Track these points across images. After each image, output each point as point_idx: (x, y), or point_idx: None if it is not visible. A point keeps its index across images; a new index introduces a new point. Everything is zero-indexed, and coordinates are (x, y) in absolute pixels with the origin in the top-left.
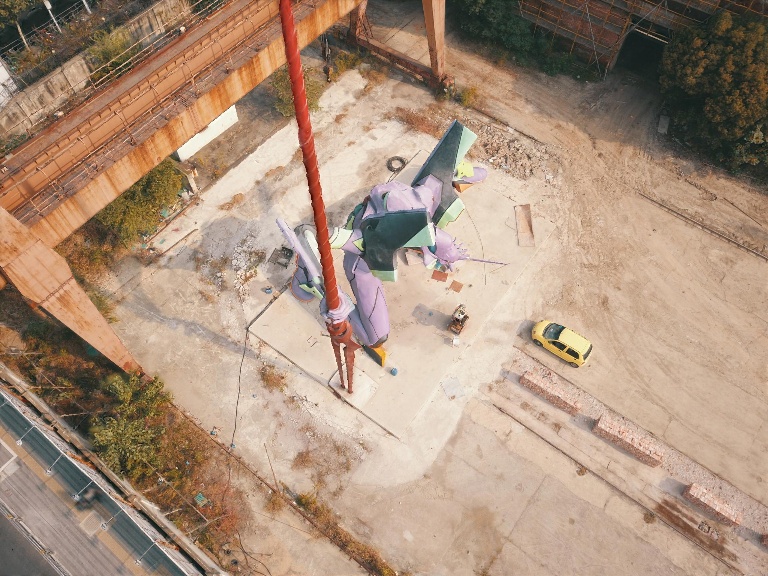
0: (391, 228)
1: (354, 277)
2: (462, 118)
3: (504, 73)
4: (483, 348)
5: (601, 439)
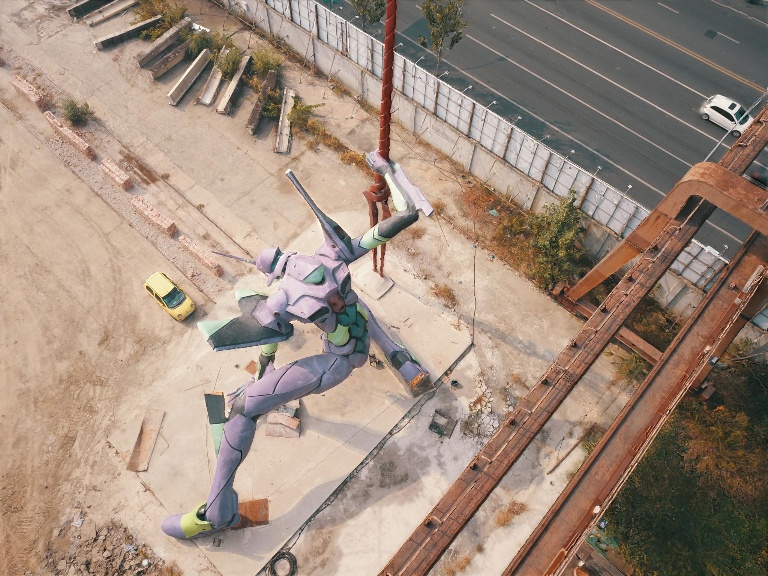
0: None
1: None
2: None
3: None
4: None
5: None
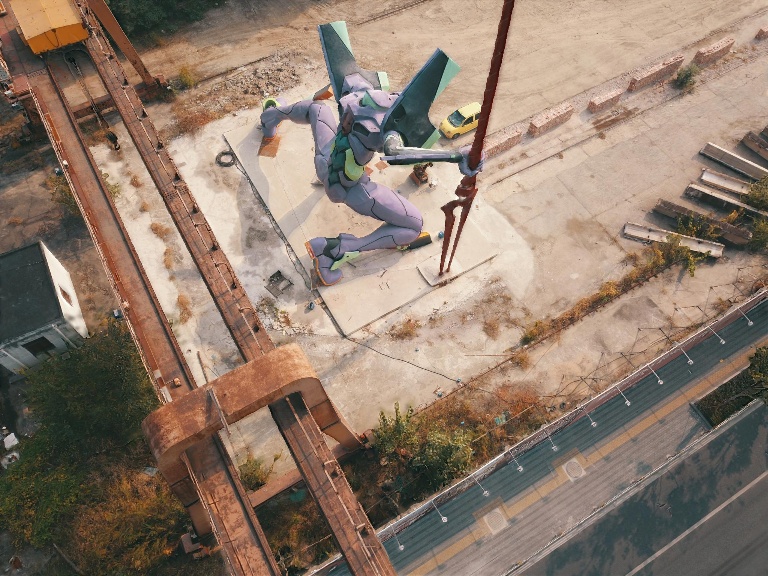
0: (417, 98)
1: (374, 200)
2: (205, 94)
3: (174, 46)
4: (444, 171)
5: (541, 136)
